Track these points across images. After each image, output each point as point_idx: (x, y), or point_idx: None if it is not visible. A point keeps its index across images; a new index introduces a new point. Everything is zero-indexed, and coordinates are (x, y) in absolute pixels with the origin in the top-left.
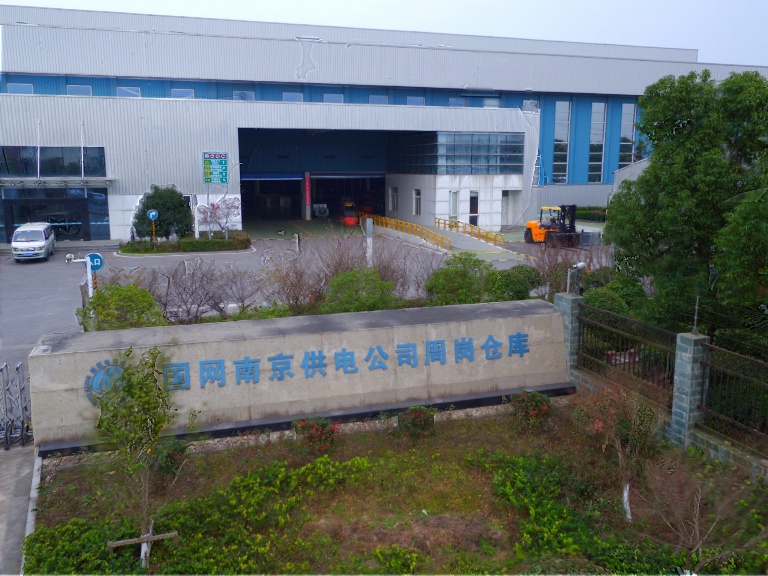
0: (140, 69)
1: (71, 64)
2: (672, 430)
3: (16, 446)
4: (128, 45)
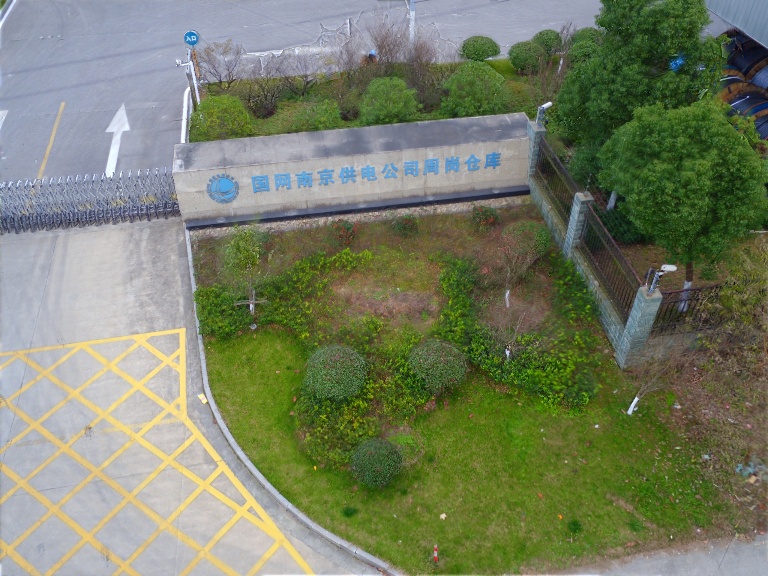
0: None
1: None
2: (565, 245)
3: (171, 216)
4: None
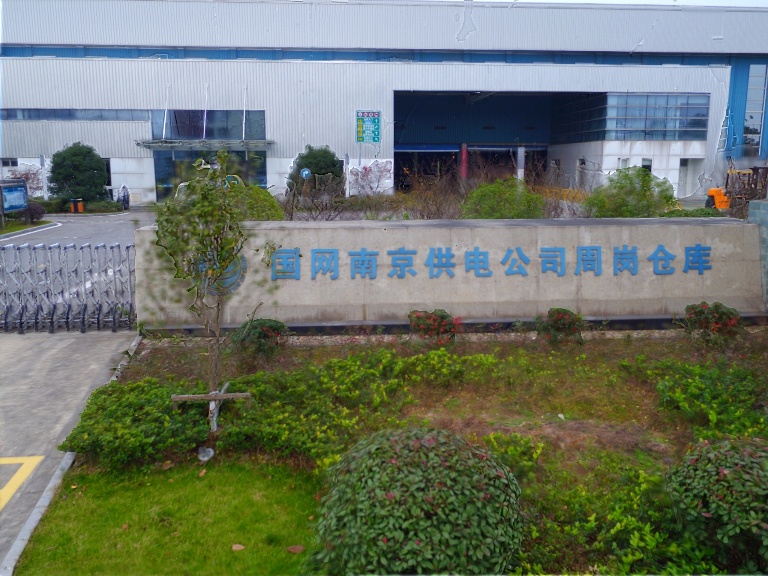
0: (304, 40)
1: (241, 37)
2: None
3: (124, 330)
4: (294, 17)
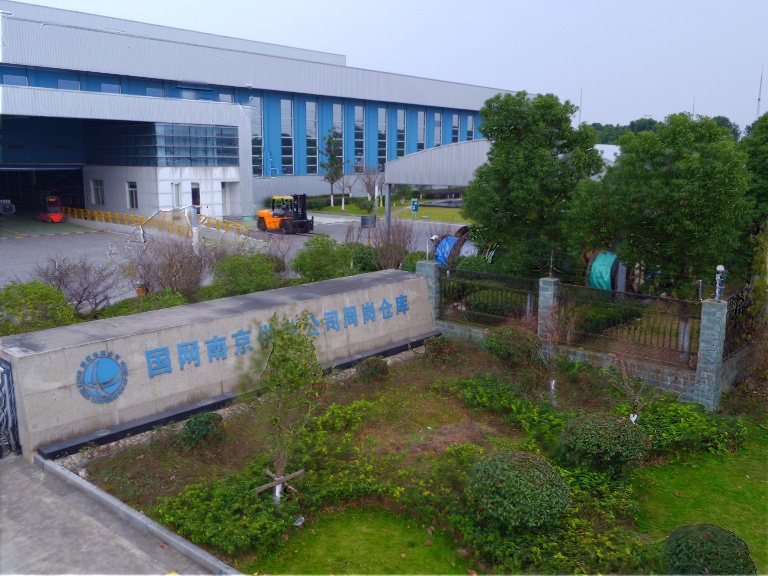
0: None
1: None
2: None
3: None
4: None
